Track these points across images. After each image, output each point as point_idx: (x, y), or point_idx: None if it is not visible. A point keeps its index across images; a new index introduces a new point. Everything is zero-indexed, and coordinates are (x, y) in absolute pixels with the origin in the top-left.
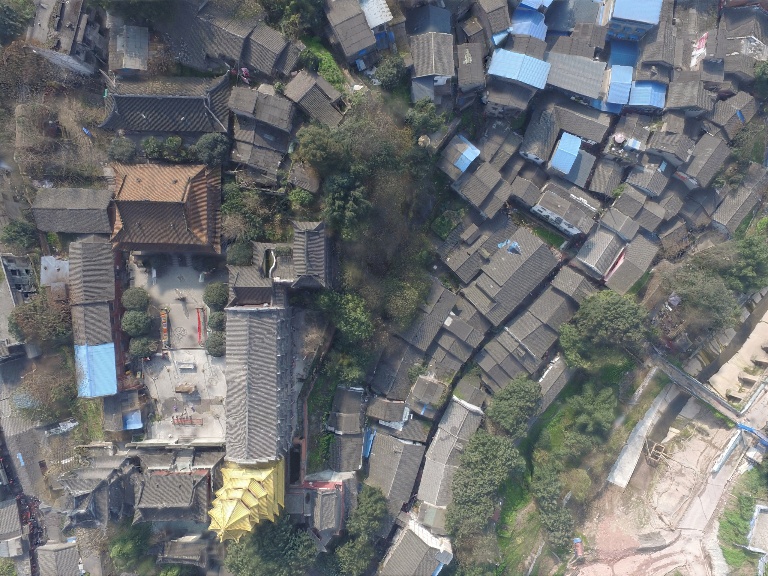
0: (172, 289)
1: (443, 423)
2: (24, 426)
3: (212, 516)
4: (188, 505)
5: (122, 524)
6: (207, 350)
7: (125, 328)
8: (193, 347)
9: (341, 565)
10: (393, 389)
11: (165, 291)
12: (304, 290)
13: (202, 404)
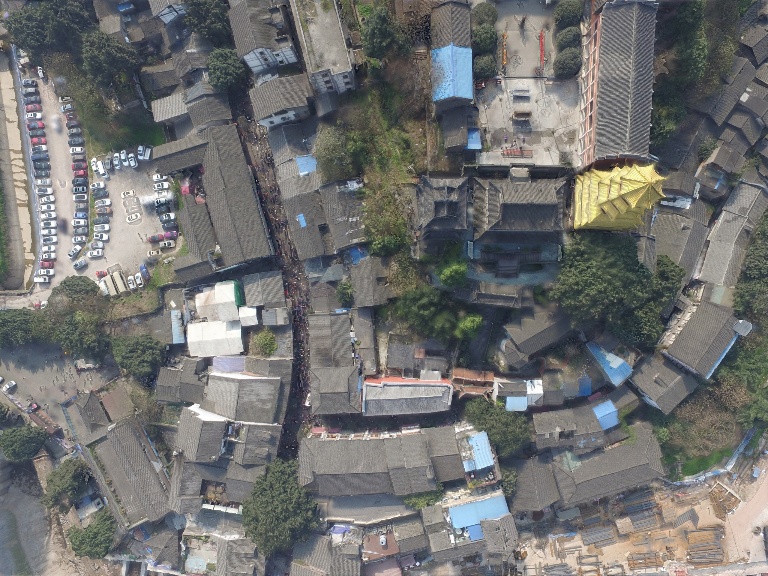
0: (511, 16)
1: (729, 205)
2: (305, 189)
3: (628, 179)
4: (558, 203)
5: (437, 261)
6: (559, 66)
7: (482, 36)
8: (529, 75)
9: (642, 326)
10: (684, 164)
11: (503, 18)
12: (661, 9)
13: (532, 136)
